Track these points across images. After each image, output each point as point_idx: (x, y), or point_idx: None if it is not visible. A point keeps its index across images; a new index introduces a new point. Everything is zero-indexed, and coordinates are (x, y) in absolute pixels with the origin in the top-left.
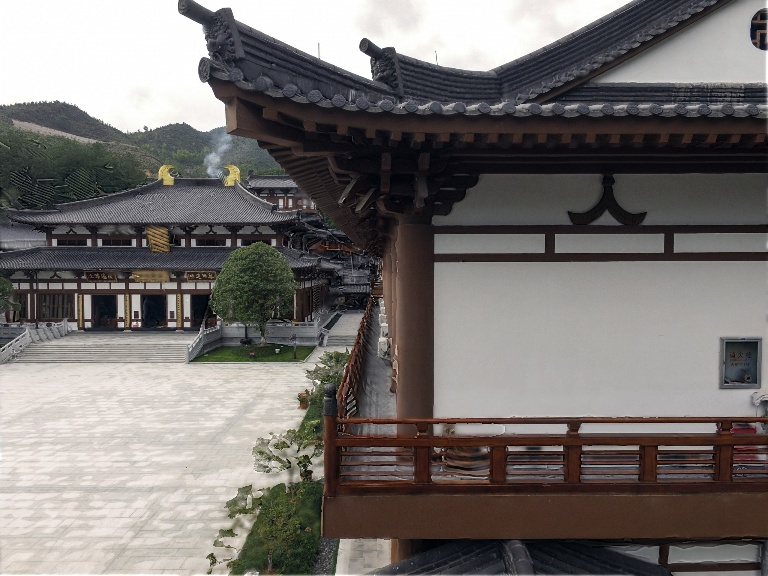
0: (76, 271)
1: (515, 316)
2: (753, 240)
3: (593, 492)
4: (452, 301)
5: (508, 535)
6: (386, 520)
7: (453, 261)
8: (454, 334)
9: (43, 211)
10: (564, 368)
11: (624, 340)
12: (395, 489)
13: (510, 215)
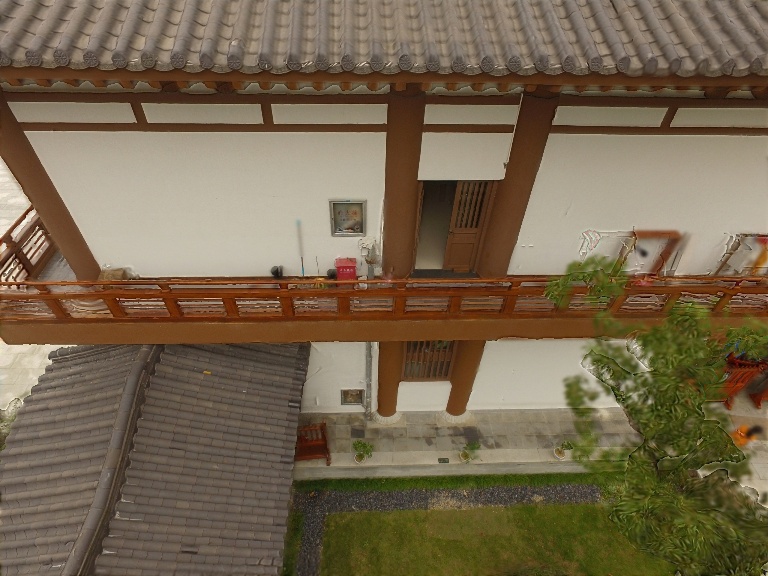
0: None
1: (131, 181)
2: (356, 112)
3: (192, 322)
4: (62, 167)
5: (139, 342)
6: (46, 336)
7: (43, 130)
8: (79, 195)
9: None
10: (193, 221)
11: (241, 200)
12: (42, 321)
13: None
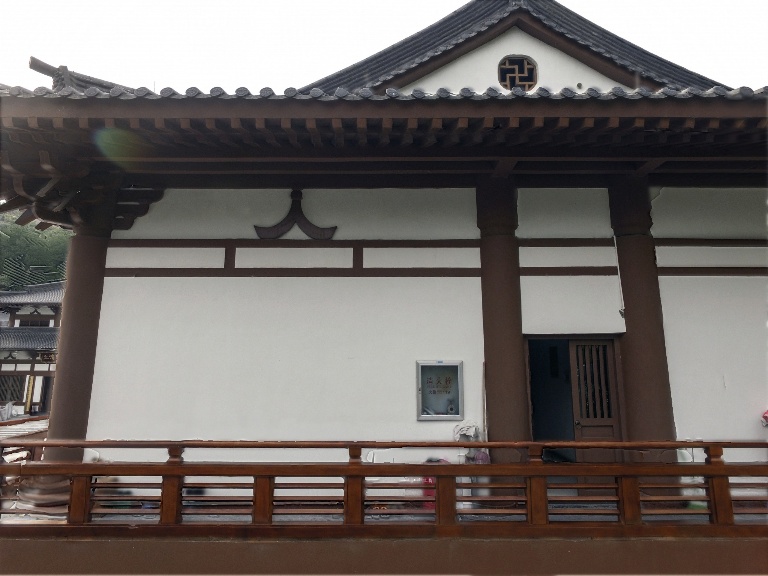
0: (31, 351)
1: (188, 336)
2: (448, 255)
3: (190, 537)
4: (119, 319)
5: None
6: None
7: (125, 276)
8: (118, 356)
9: (11, 292)
10: (239, 395)
11: (309, 363)
12: None
13: (192, 229)
